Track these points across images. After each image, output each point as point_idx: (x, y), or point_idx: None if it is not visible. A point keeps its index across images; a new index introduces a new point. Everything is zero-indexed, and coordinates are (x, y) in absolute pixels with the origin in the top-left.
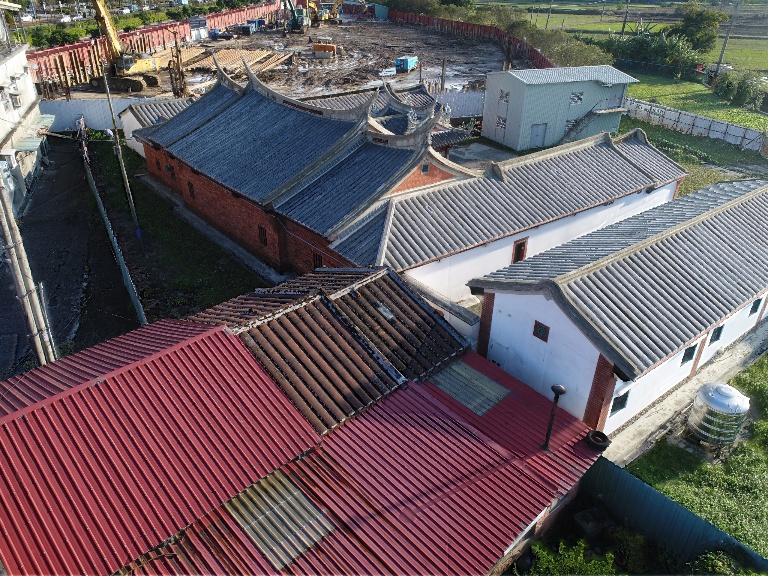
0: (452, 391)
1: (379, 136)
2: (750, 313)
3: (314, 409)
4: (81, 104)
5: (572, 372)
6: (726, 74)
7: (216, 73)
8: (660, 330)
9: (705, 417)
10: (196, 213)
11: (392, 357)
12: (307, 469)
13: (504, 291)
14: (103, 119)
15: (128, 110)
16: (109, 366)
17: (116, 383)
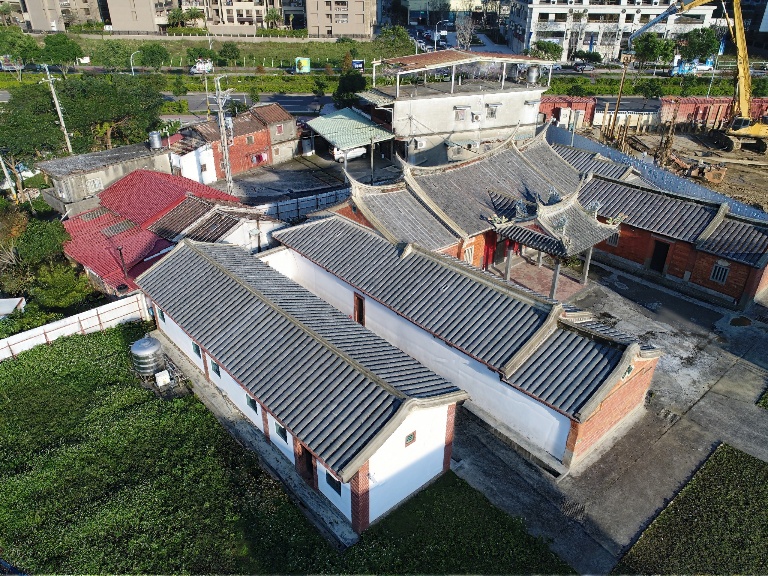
0: None
1: None
2: (254, 407)
3: None
4: (575, 137)
5: None
6: None
7: None
8: None
9: None
10: None
11: (188, 237)
12: None
13: None
14: None
15: None
16: None
17: None
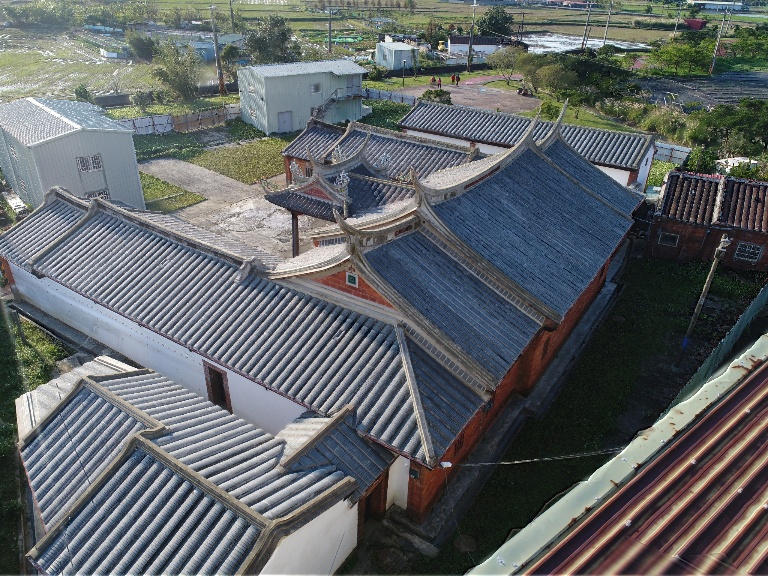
0: None
1: None
2: None
3: None
4: None
5: None
6: None
7: None
8: None
9: None
10: None
11: None
12: None
13: None
14: None
15: None
16: None
17: None
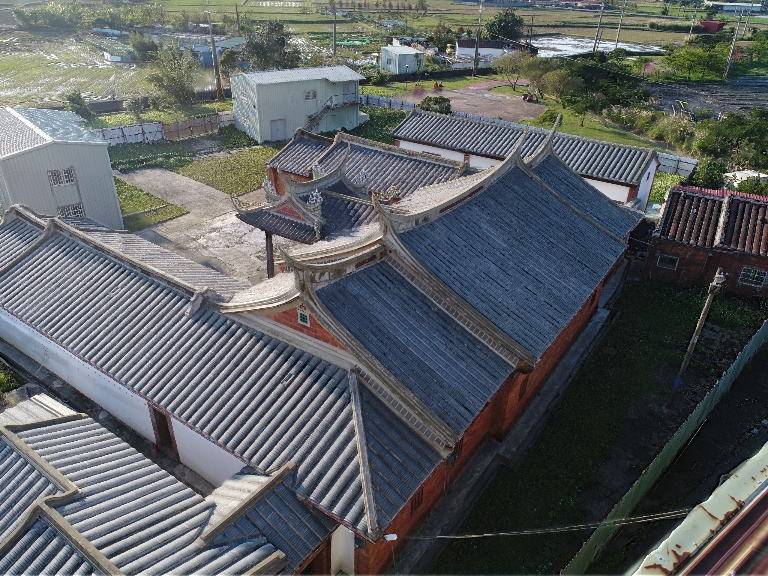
0: None
1: None
2: None
3: None
4: None
5: None
6: None
7: None
8: None
9: None
10: None
11: None
12: None
13: None
14: None
15: None
16: None
17: None
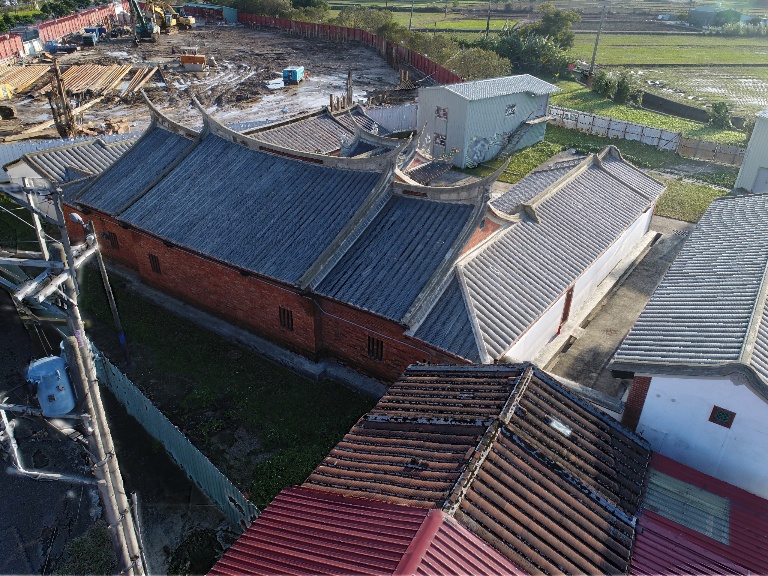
0: (677, 517)
1: (413, 188)
2: None
3: None
4: None
5: (766, 458)
6: (601, 73)
7: (79, 96)
8: None
9: None
10: (163, 290)
11: (600, 489)
12: None
13: (669, 375)
14: None
15: (21, 162)
16: None
17: None
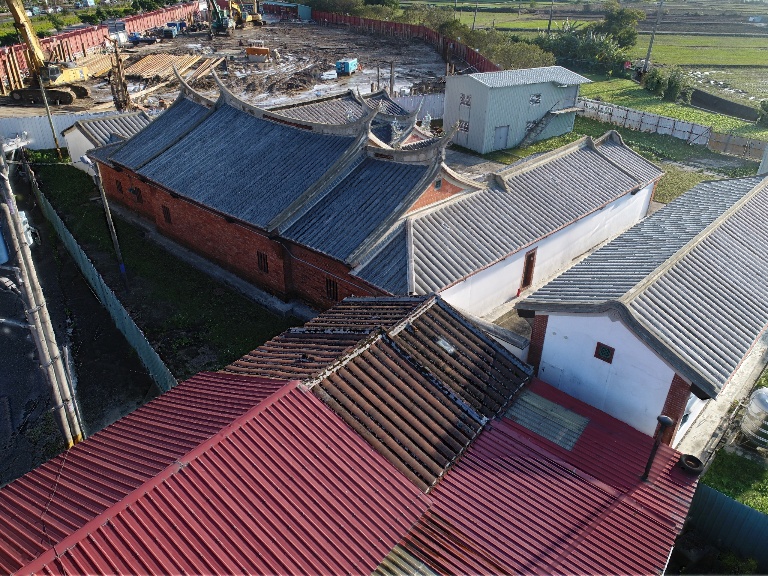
0: (533, 426)
1: (382, 151)
2: None
3: (409, 465)
4: (15, 122)
5: (641, 392)
6: None
7: (148, 81)
8: (720, 343)
9: (764, 424)
10: (173, 239)
11: (465, 395)
12: (422, 536)
13: (561, 313)
14: (41, 137)
15: (74, 128)
16: (177, 442)
17: (201, 465)
